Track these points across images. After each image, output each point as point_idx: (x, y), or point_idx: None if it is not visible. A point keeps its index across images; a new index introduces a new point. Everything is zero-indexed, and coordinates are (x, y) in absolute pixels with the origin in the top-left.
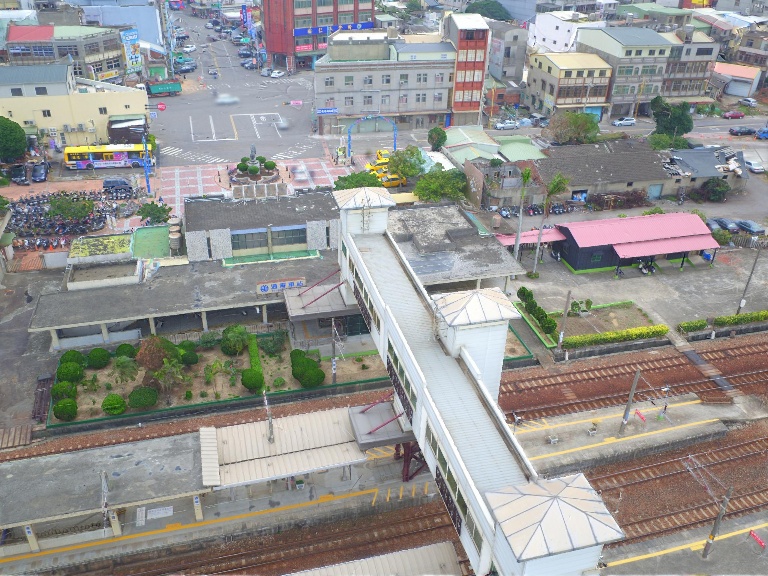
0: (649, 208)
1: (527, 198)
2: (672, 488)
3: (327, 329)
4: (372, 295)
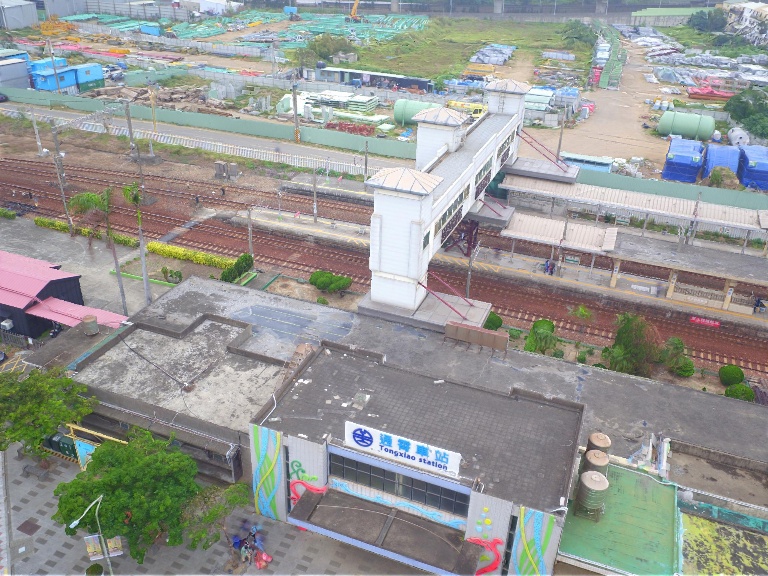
0: None
1: None
2: (326, 213)
3: None
4: None
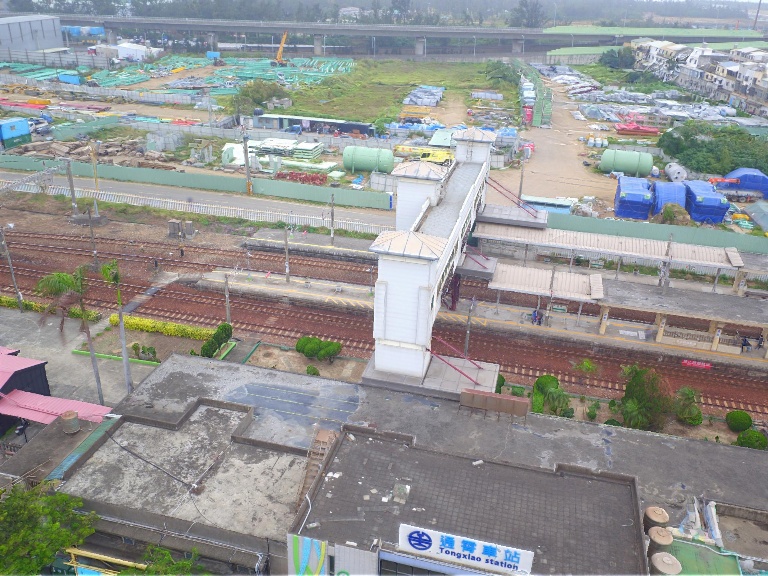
0: None
1: None
2: (295, 270)
3: None
4: None
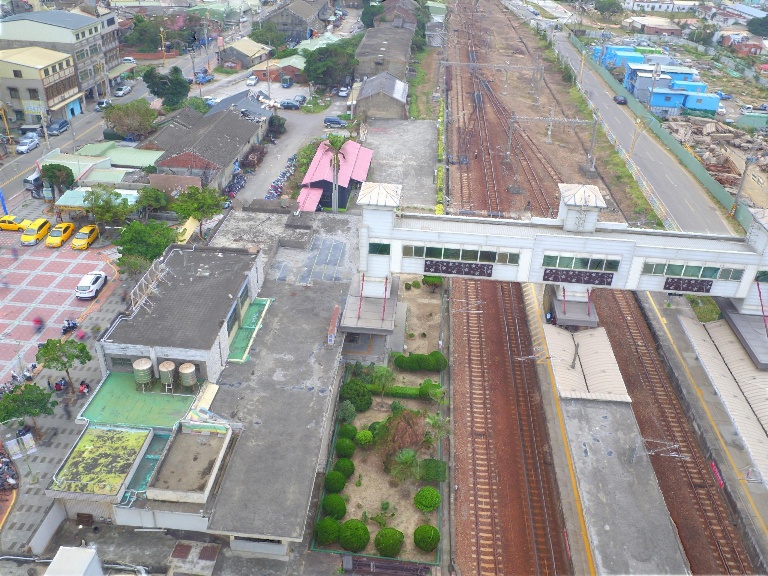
0: (269, 155)
1: (219, 185)
2: None
3: (360, 340)
4: (494, 244)
